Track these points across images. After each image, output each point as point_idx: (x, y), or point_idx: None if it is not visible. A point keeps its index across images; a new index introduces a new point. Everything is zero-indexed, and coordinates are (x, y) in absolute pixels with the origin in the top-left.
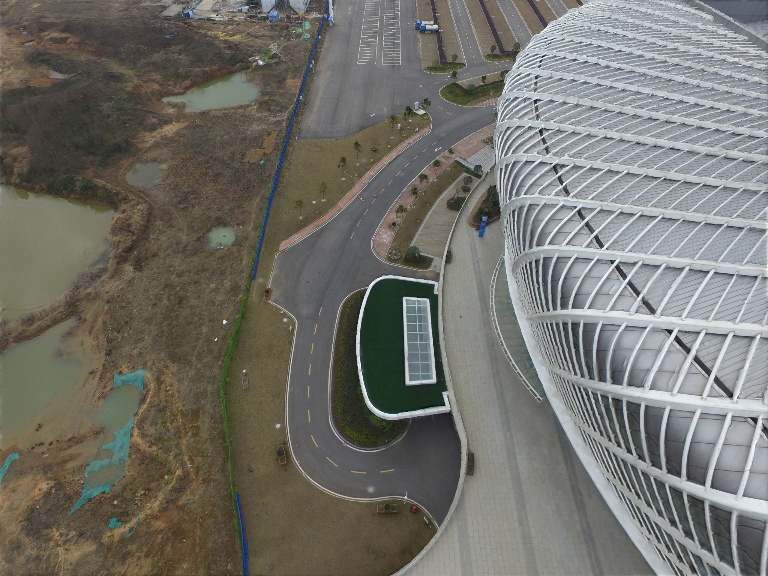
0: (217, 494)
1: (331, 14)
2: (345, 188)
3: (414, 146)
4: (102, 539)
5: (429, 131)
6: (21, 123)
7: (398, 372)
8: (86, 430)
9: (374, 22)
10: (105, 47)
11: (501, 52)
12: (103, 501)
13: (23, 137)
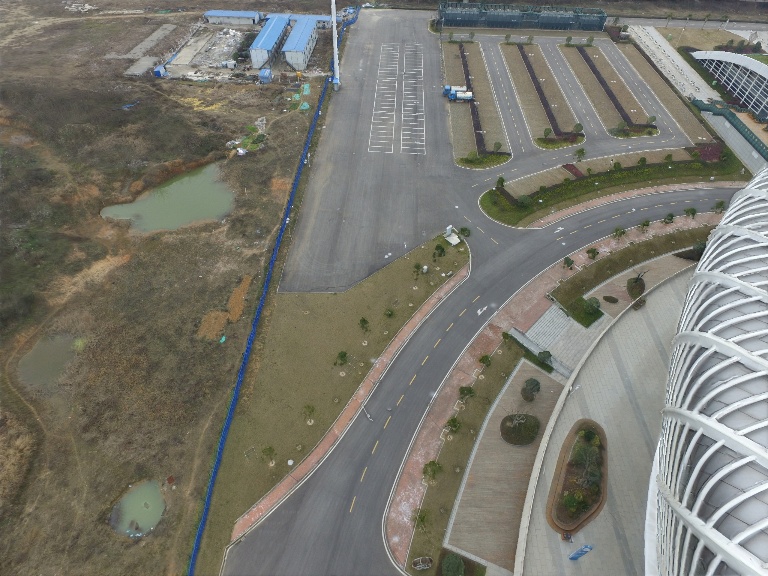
0: None
1: (337, 75)
2: (344, 393)
3: (447, 304)
4: None
5: (467, 275)
6: None
7: None
8: None
9: (391, 84)
10: (41, 125)
11: (556, 134)
12: None
13: None
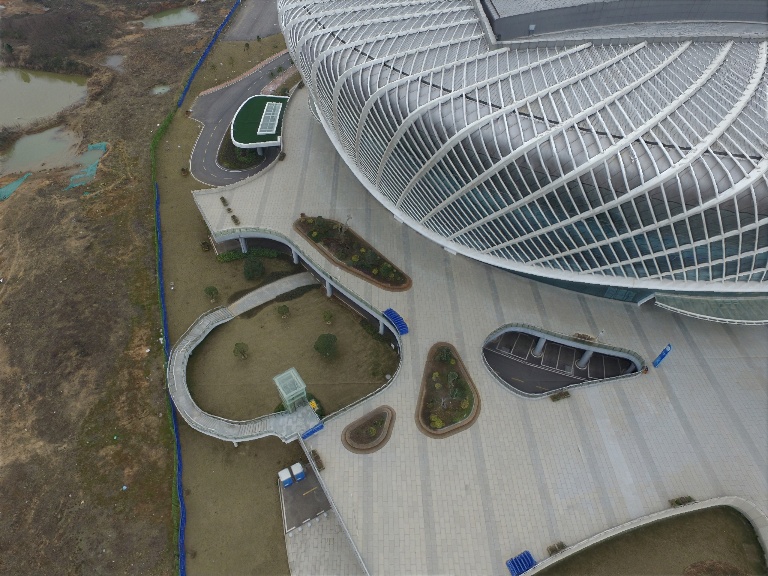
0: (145, 185)
1: None
2: (250, 66)
3: None
4: (80, 198)
5: None
6: (23, 32)
7: (254, 130)
8: (71, 165)
9: None
10: None
11: None
12: (81, 187)
13: (25, 41)
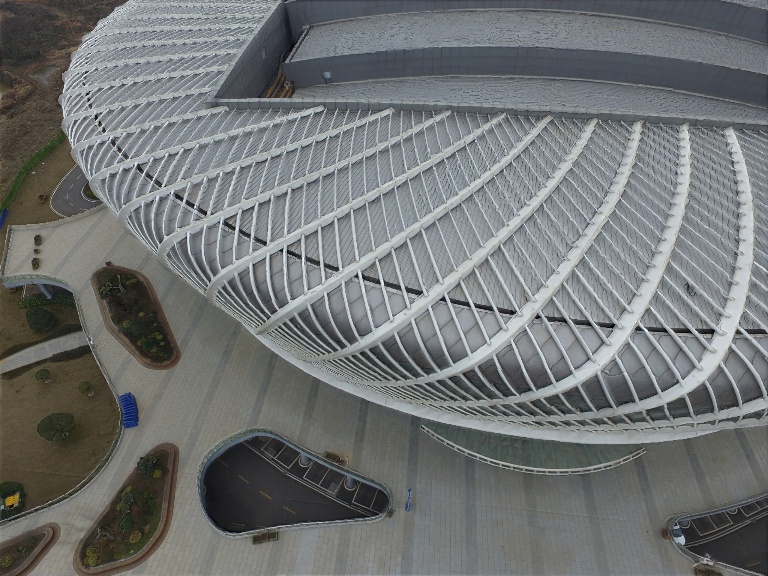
0: None
1: None
2: None
3: None
4: None
5: None
6: None
7: None
8: None
9: None
10: (55, 0)
11: None
12: None
13: None
